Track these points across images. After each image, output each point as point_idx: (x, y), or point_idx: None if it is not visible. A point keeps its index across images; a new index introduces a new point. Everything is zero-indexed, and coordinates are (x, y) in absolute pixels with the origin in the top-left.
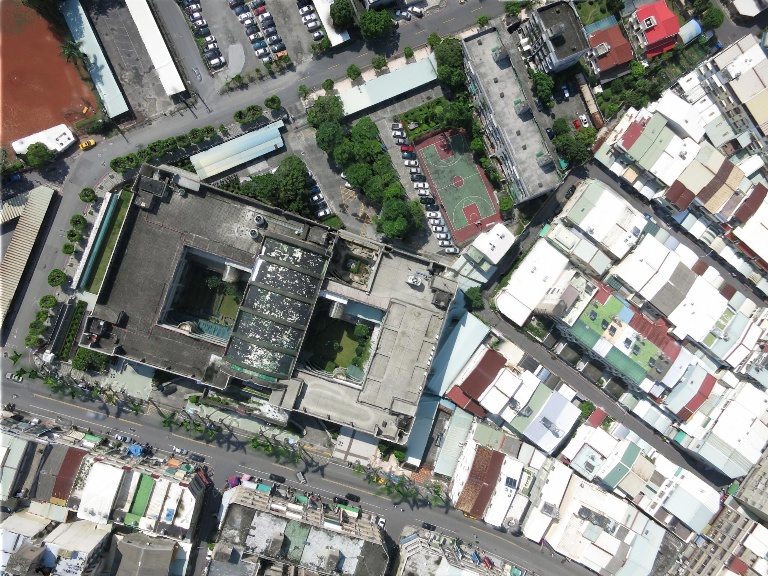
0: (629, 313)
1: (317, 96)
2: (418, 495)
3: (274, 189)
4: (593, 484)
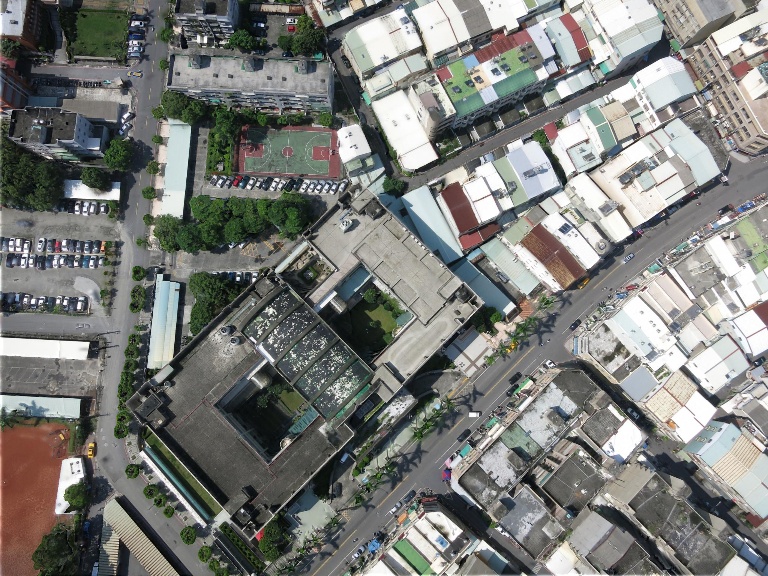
0: (471, 59)
1: None
2: (542, 320)
3: (208, 307)
4: (606, 161)
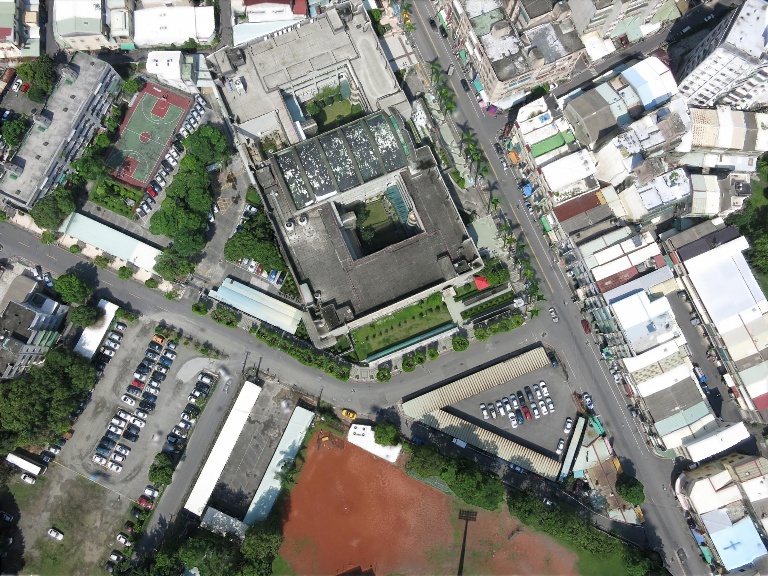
0: None
1: (168, 288)
2: None
3: None
4: None
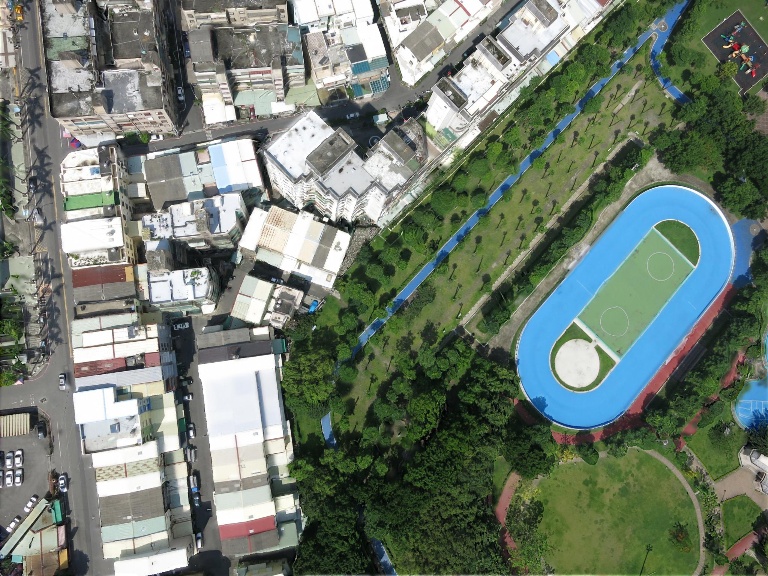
0: None
1: None
2: None
3: None
4: None
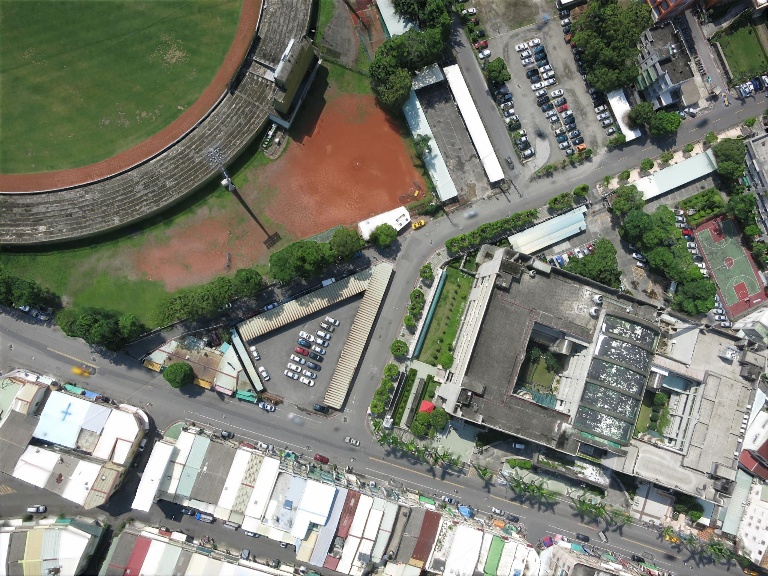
0: None
1: (610, 184)
2: (703, 553)
3: (599, 270)
4: None
